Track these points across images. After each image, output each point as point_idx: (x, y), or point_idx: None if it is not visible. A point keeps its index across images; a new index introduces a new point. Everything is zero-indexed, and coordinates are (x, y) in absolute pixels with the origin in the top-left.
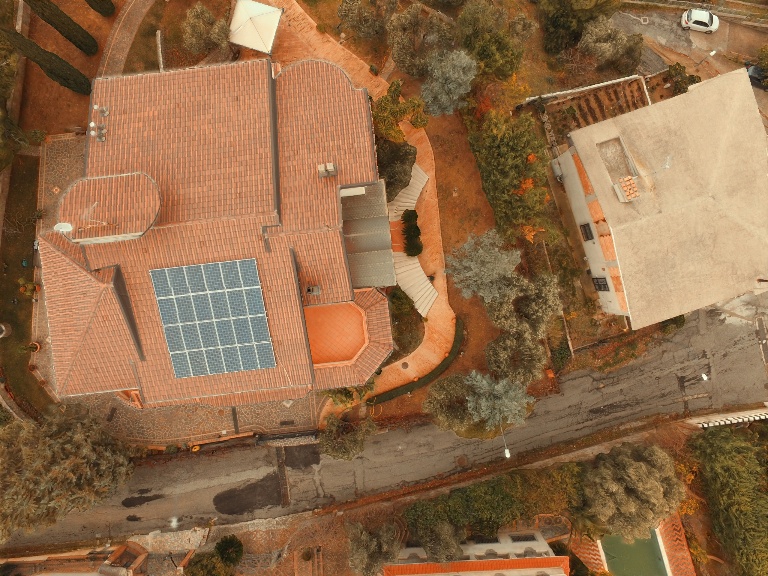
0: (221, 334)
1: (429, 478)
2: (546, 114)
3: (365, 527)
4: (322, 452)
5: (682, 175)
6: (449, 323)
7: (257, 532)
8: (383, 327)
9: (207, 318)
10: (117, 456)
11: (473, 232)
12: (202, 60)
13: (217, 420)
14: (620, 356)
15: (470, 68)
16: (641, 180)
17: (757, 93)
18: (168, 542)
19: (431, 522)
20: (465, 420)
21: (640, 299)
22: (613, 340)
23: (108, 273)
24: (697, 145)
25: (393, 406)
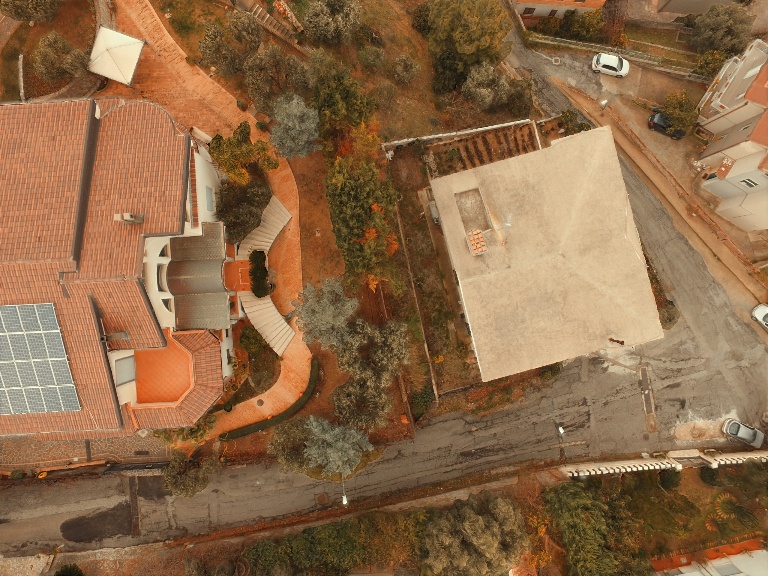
0: (22, 375)
1: (286, 514)
2: (432, 154)
3: (202, 565)
4: None
5: (535, 231)
6: (305, 363)
7: (104, 561)
8: (213, 370)
9: (7, 359)
10: None
11: (334, 273)
12: (64, 87)
13: (69, 447)
14: (494, 400)
15: (309, 116)
16: (494, 233)
17: (664, 140)
18: (10, 567)
19: (269, 563)
20: (304, 464)
21: (490, 352)
22: (484, 385)
23: None
24: (553, 201)
25: (247, 442)
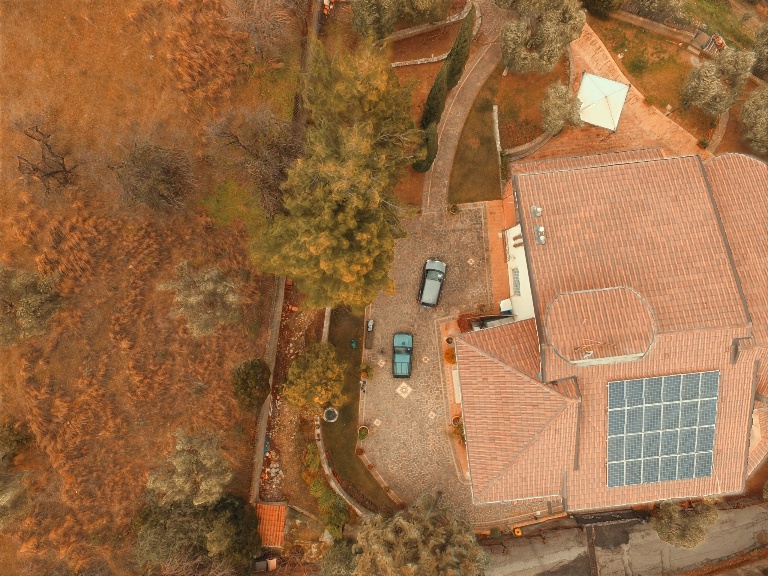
0: (664, 444)
1: (731, 555)
2: None
3: None
4: (631, 531)
5: None
6: None
7: None
8: None
9: (654, 429)
10: (486, 552)
11: None
12: (539, 136)
13: None
14: None
15: None
16: None
17: None
18: None
19: None
20: None
21: None
22: None
23: (569, 386)
24: None
25: None
